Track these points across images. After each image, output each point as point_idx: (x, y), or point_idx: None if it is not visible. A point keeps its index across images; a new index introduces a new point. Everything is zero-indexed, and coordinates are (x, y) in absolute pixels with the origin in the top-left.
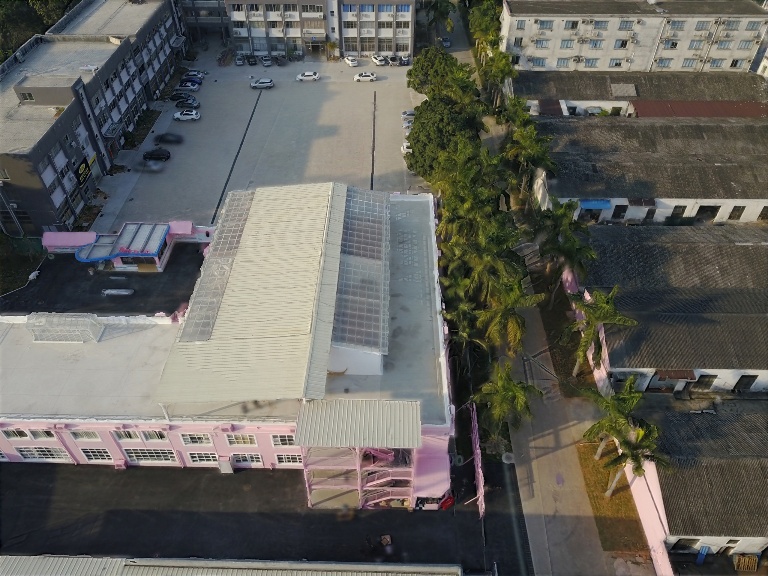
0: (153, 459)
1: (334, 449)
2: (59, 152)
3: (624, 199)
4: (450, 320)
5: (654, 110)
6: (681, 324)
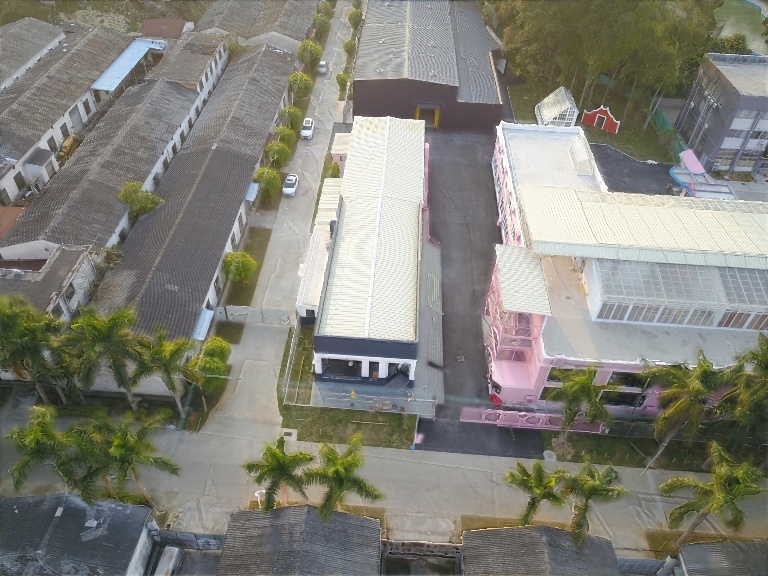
0: None
1: None
2: None
3: None
4: None
5: None
6: None
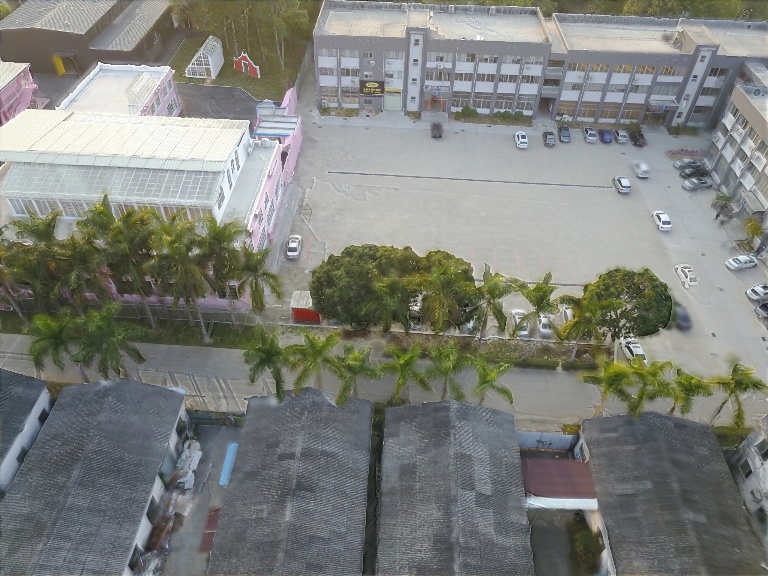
0: None
1: None
2: (355, 58)
3: None
4: None
5: None
6: None
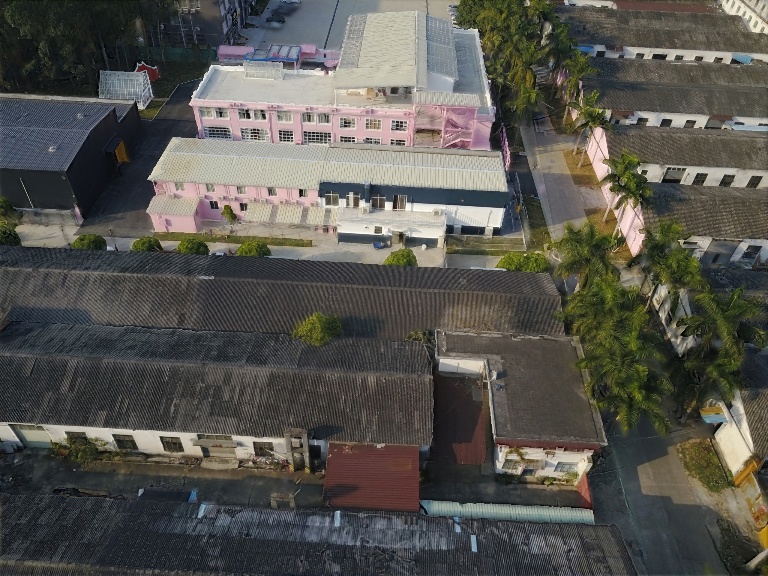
0: (317, 142)
1: (432, 112)
2: None
3: (603, 46)
4: (492, 78)
5: (630, 7)
6: (629, 89)
